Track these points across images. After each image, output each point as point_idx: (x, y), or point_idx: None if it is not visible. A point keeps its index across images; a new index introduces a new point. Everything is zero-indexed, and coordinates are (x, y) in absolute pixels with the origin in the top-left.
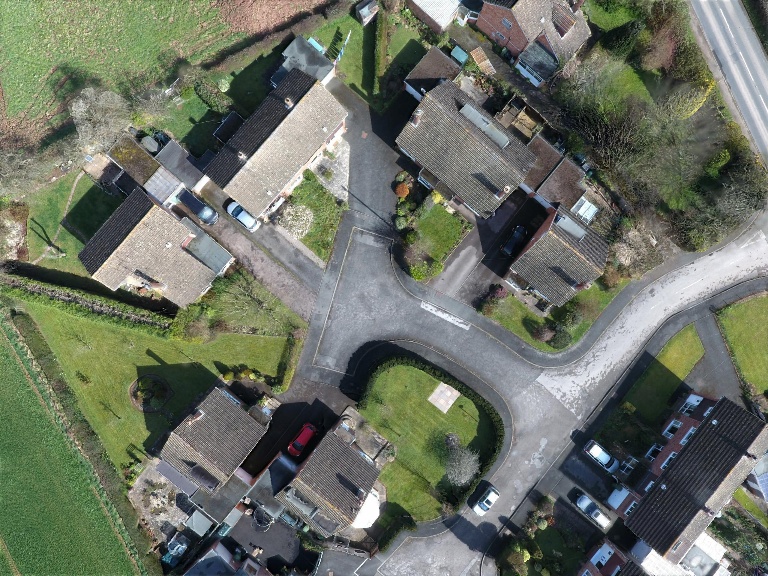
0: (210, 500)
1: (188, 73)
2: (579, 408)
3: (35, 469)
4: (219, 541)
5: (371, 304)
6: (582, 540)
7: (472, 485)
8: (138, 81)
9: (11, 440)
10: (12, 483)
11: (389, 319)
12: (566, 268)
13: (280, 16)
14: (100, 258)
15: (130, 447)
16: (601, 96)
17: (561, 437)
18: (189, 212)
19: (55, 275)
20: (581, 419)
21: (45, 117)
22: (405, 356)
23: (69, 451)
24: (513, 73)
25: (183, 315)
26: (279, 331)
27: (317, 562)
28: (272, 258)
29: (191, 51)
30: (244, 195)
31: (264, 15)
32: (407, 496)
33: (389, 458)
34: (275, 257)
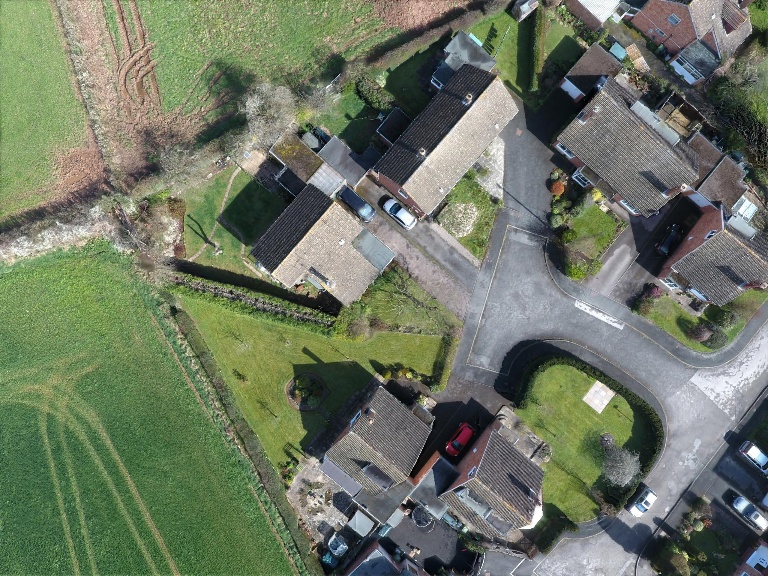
0: (374, 500)
1: (349, 69)
2: (733, 409)
3: (193, 468)
4: (377, 541)
5: (525, 303)
6: (737, 542)
7: (633, 486)
8: (292, 77)
9: (169, 438)
10: (171, 482)
11: (543, 318)
12: (736, 267)
13: (435, 12)
14: (278, 255)
15: (287, 446)
16: (754, 94)
17: (715, 438)
18: (345, 209)
19: (211, 272)
20: (734, 420)
21: (200, 113)
22: None
23: (227, 450)
24: (667, 70)
25: (346, 313)
26: (434, 330)
27: (474, 563)
28: (427, 256)
29: (345, 47)
30: (419, 192)
31: (420, 11)
32: (563, 497)
33: (545, 458)
34: (430, 255)
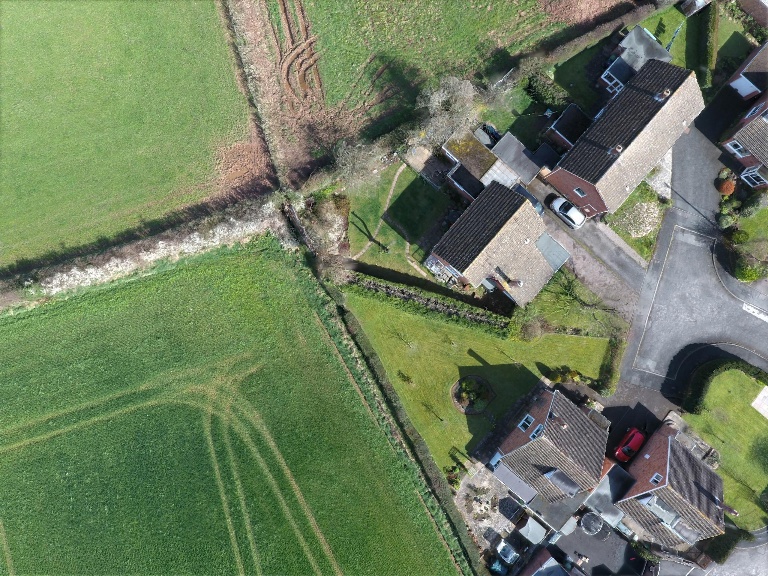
0: (548, 507)
1: (522, 63)
2: None
3: (358, 472)
4: None
5: (693, 305)
6: None
7: None
8: (457, 71)
9: (334, 441)
10: (337, 486)
11: (711, 321)
12: None
13: (602, 6)
14: (467, 254)
15: (453, 450)
16: None
17: None
18: None
19: (375, 271)
20: None
21: (363, 107)
22: (736, 360)
23: (393, 454)
24: None
25: (520, 314)
26: (601, 332)
27: (643, 572)
28: (594, 256)
29: (509, 41)
30: (609, 190)
31: (588, 5)
32: (731, 505)
33: (714, 465)
34: (596, 255)
